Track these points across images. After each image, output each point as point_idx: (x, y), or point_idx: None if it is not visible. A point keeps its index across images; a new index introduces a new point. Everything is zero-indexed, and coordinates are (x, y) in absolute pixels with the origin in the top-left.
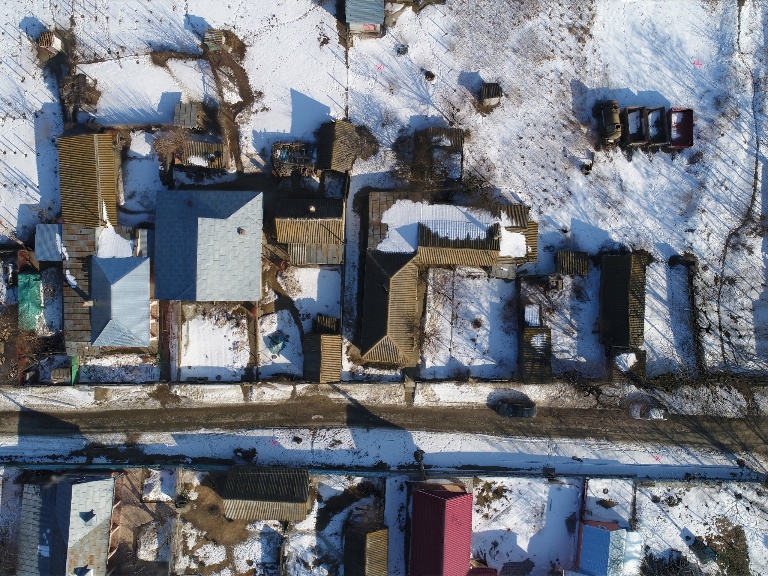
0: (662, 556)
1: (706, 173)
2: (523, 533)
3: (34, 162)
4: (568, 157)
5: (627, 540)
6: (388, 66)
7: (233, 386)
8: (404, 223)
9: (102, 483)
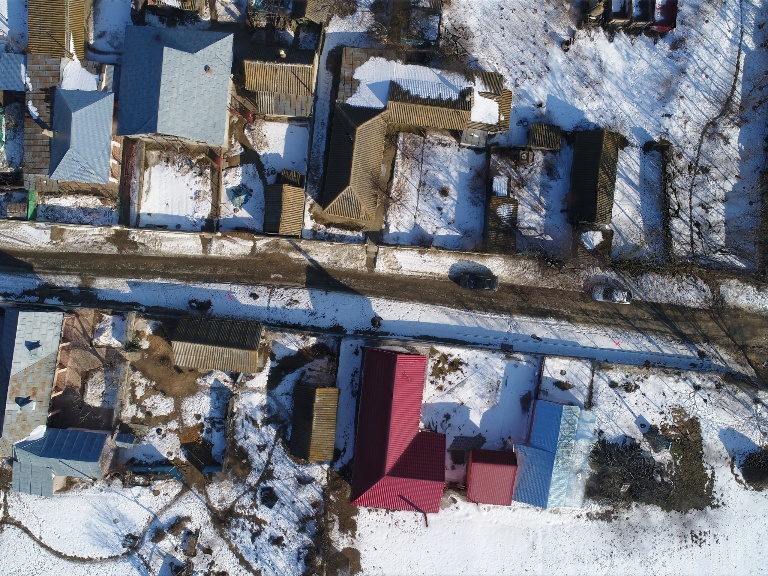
0: (615, 441)
1: (687, 59)
2: (476, 408)
3: None
4: (549, 32)
5: (580, 418)
6: None
7: (192, 236)
8: (376, 80)
9: (50, 316)
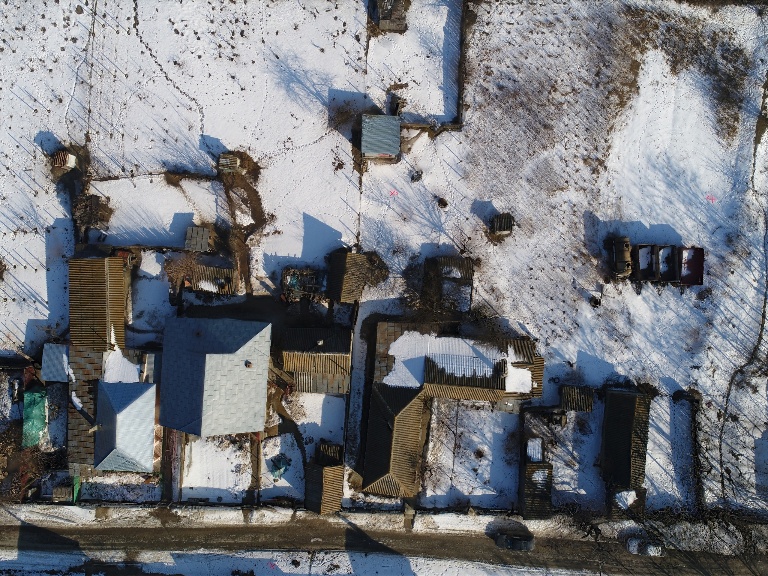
0: None
1: (714, 310)
2: None
3: (44, 277)
4: (577, 289)
5: None
6: (401, 192)
7: (234, 508)
8: (411, 356)
9: None
